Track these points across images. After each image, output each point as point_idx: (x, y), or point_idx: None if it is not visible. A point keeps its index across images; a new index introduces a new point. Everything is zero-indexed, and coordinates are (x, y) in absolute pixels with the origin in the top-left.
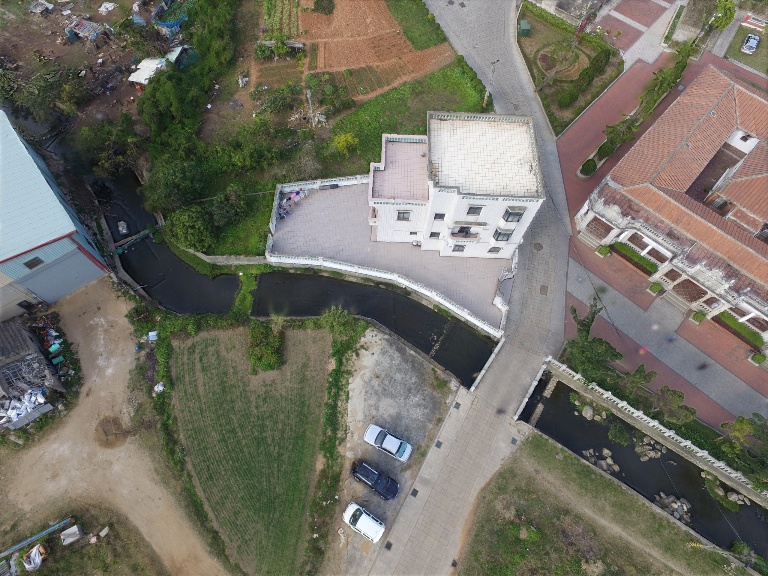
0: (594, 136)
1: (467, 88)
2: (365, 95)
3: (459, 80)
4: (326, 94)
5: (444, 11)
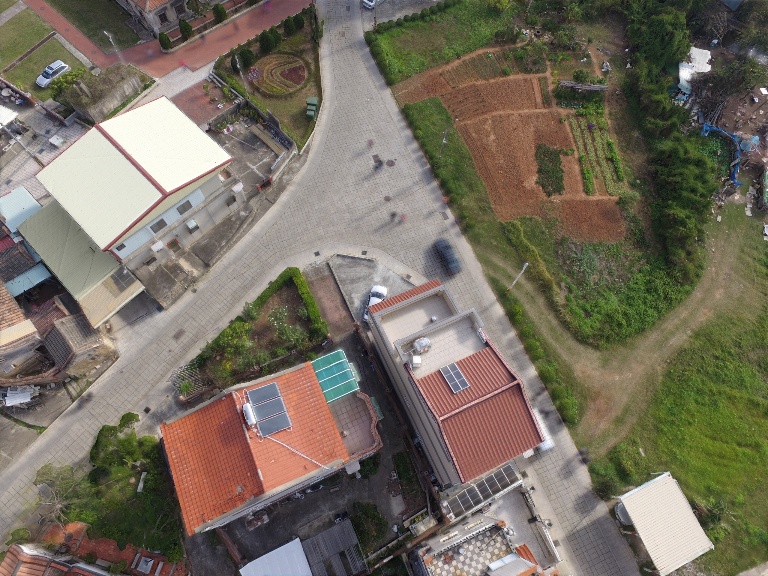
0: (280, 5)
1: (388, 50)
2: (487, 51)
3: (394, 60)
4: (524, 51)
5: (401, 151)
